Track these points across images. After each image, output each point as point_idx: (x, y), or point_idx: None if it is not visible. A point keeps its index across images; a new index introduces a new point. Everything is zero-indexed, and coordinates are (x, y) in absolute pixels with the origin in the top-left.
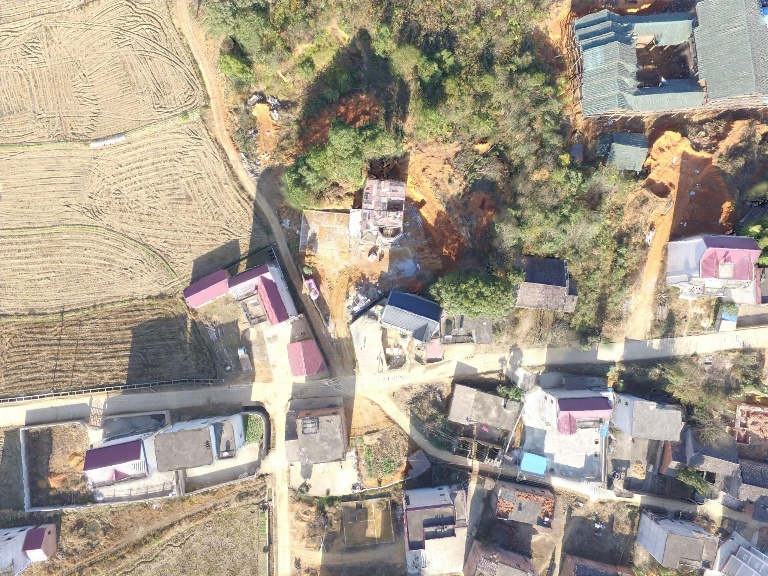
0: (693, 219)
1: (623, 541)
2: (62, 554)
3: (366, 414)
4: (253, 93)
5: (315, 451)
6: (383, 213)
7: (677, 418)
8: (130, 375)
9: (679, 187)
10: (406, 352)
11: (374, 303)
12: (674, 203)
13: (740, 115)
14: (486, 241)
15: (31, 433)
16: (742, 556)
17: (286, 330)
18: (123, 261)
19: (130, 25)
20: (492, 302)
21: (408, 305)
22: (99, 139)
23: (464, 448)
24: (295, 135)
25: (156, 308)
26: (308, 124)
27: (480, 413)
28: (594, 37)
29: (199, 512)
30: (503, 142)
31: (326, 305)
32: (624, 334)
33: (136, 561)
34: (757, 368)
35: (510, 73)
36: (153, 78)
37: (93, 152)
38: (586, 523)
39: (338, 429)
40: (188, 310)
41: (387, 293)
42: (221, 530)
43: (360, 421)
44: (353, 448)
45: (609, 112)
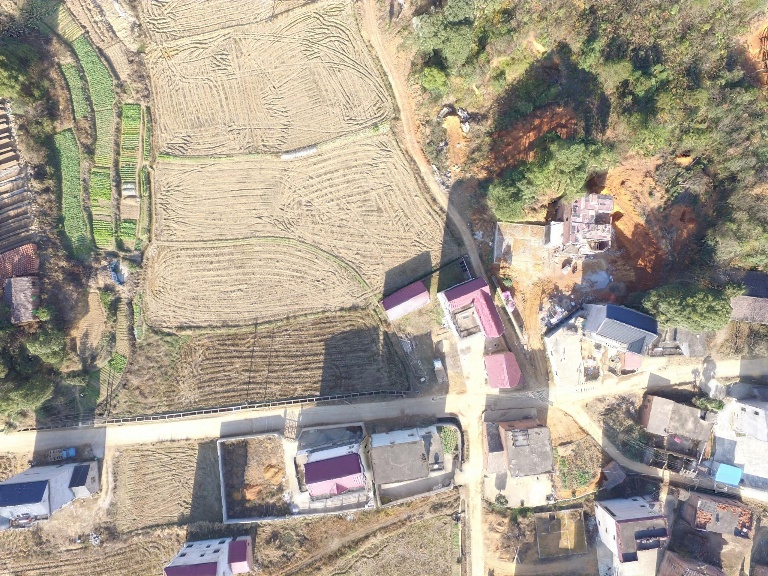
0: None
1: None
2: (258, 566)
3: (560, 425)
4: (443, 105)
5: (525, 463)
6: (592, 226)
7: None
8: (323, 387)
9: None
10: (599, 364)
11: (571, 315)
12: None
13: None
14: (687, 253)
15: (227, 445)
16: None
17: (479, 342)
18: (315, 273)
19: (318, 37)
20: (723, 316)
21: (625, 318)
22: (290, 151)
23: (660, 459)
24: (486, 147)
25: (348, 320)
26: (500, 136)
27: (677, 424)
28: None
29: (393, 523)
30: (707, 155)
31: (520, 317)
32: None
33: (330, 573)
34: None
35: (720, 87)
36: (342, 90)
37: (284, 164)
38: None
39: (547, 441)
40: (380, 322)
41: (580, 305)
42: (414, 541)
43: (554, 432)
44: None
45: None
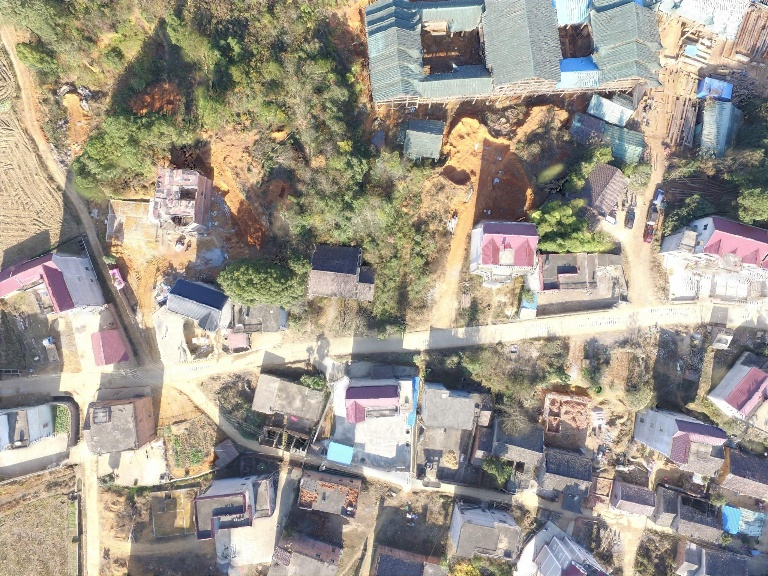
0: (497, 207)
1: (437, 531)
2: None
3: (174, 404)
4: (64, 83)
5: (107, 440)
6: (175, 202)
7: (470, 406)
8: None
9: (481, 174)
10: (214, 342)
11: None
12: (476, 190)
13: (543, 101)
14: (285, 230)
15: None
16: (552, 546)
17: (94, 320)
18: None
19: None
20: (261, 289)
21: (191, 293)
22: None
23: (269, 438)
24: None
25: None
26: None
27: (284, 402)
28: (378, 23)
29: (8, 502)
30: (298, 130)
31: (134, 295)
32: (429, 323)
33: None
34: (560, 356)
35: (299, 60)
36: None
37: None
38: (399, 513)
39: (131, 418)
40: None
41: None
42: (31, 520)
43: (168, 411)
44: (161, 438)
45: (399, 99)
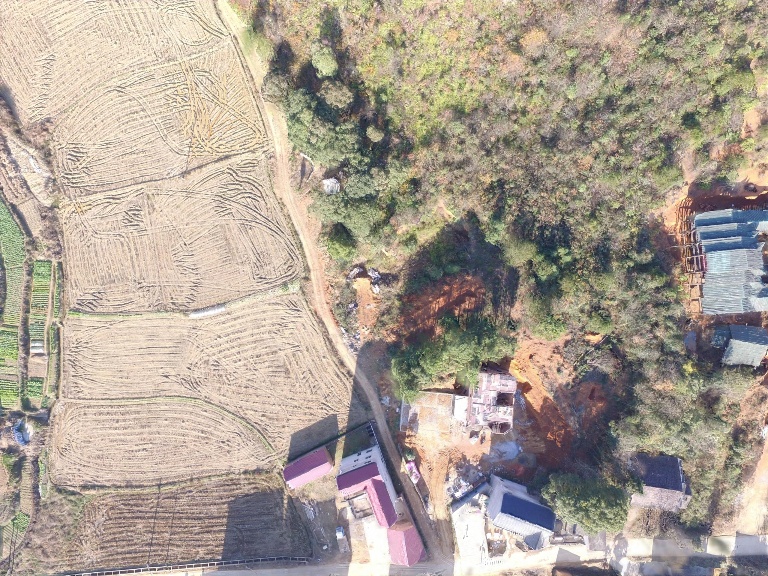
0: None
1: None
2: None
3: None
4: (354, 265)
5: None
6: (493, 408)
7: None
8: (225, 550)
9: None
10: (507, 537)
11: (476, 488)
12: None
13: None
14: (595, 433)
15: None
16: None
17: None
18: (220, 434)
19: (231, 193)
20: (615, 525)
21: (521, 511)
22: (199, 310)
23: None
24: (396, 310)
25: (252, 482)
26: (410, 300)
27: None
28: (718, 239)
29: None
30: (616, 334)
31: (426, 486)
32: (735, 528)
33: None
34: None
35: (628, 270)
36: (253, 248)
37: (192, 322)
38: None
39: None
40: (285, 486)
41: (488, 476)
42: None
43: None
44: None
45: None
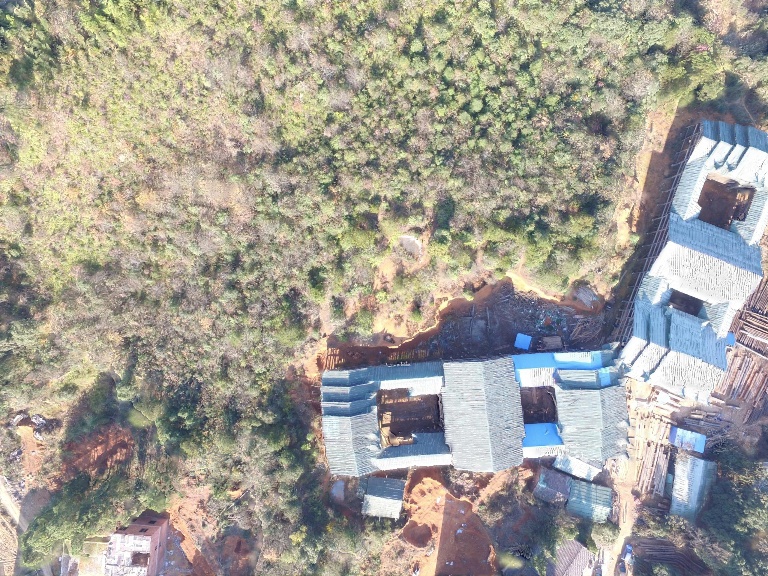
0: (460, 557)
1: None
2: None
3: None
4: (17, 412)
5: None
6: (126, 569)
7: None
8: None
9: (443, 528)
10: None
11: None
12: (438, 544)
13: None
14: None
15: None
16: None
17: None
18: None
19: None
20: None
21: None
22: None
23: None
24: (58, 458)
25: None
26: (70, 448)
27: None
28: (333, 402)
29: None
30: (254, 490)
31: None
32: None
33: None
34: None
35: (252, 431)
36: None
37: None
38: None
39: None
40: None
41: None
42: None
43: None
44: None
45: None
